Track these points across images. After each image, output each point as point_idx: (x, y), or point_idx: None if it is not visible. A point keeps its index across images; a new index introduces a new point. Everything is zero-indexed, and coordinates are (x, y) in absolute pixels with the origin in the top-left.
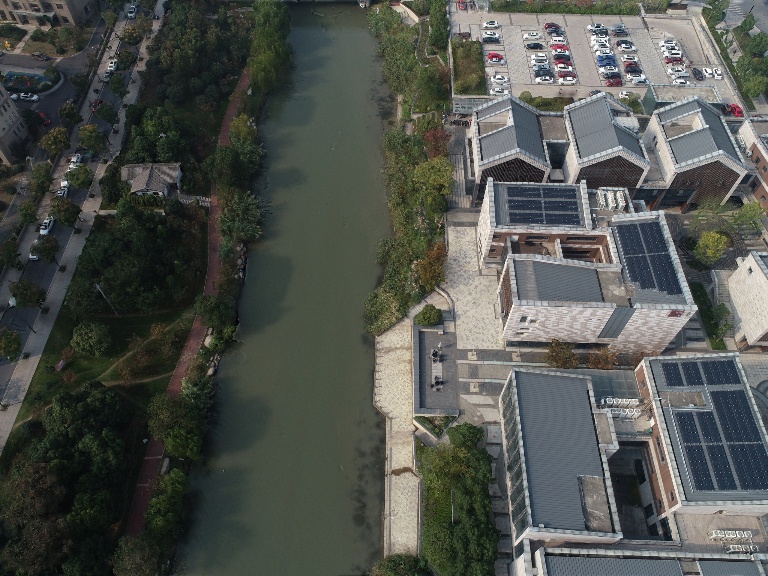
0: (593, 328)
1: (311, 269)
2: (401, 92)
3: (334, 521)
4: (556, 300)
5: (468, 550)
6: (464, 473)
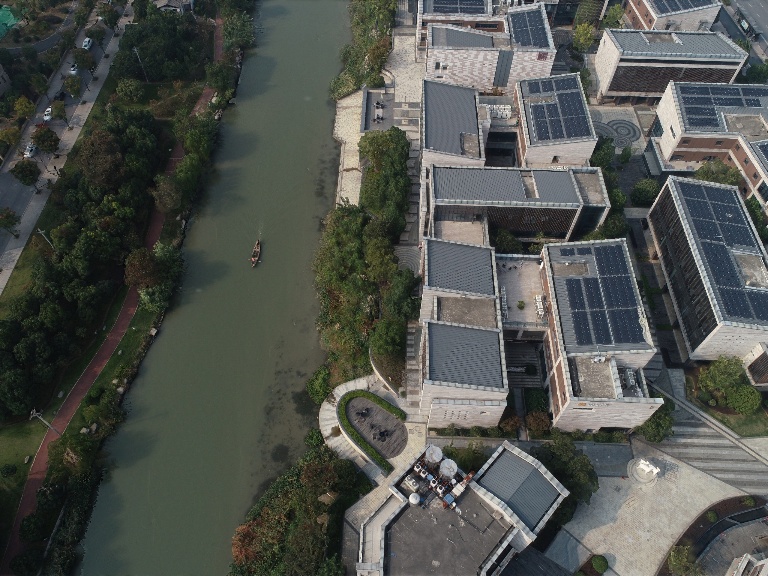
0: (488, 75)
1: None
2: None
3: (302, 195)
4: None
5: (388, 184)
6: (389, 147)
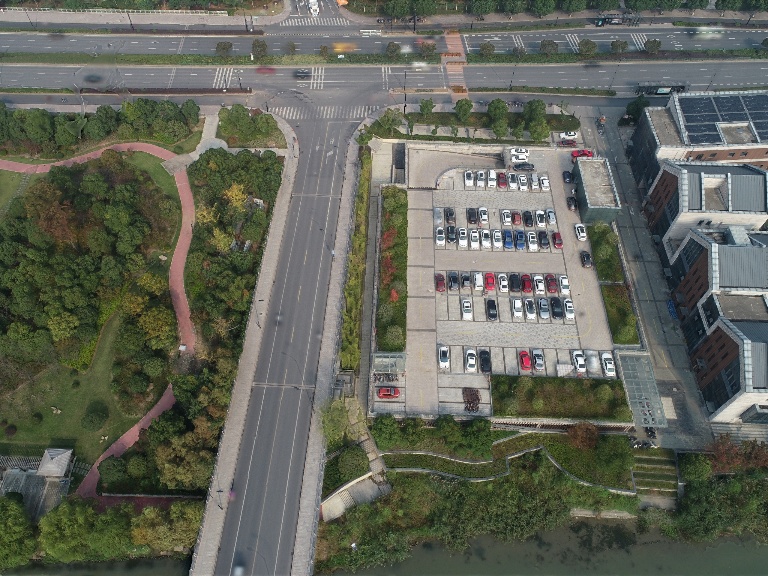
0: None
1: None
2: (570, 510)
3: None
4: None
5: None
6: None
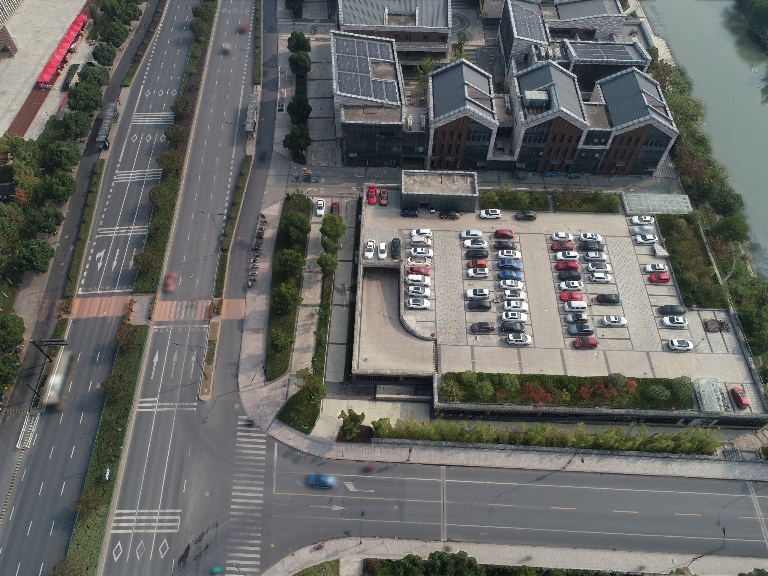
0: None
1: (744, 108)
2: None
3: None
4: (590, 2)
5: None
6: None
